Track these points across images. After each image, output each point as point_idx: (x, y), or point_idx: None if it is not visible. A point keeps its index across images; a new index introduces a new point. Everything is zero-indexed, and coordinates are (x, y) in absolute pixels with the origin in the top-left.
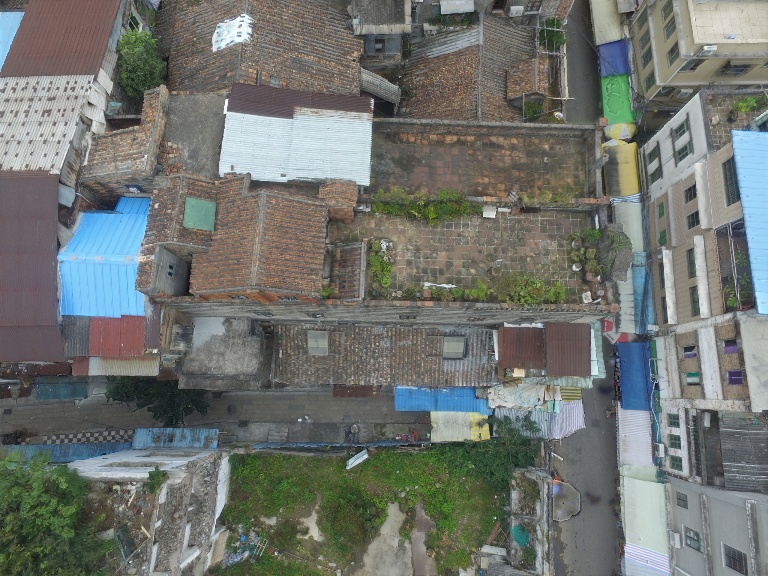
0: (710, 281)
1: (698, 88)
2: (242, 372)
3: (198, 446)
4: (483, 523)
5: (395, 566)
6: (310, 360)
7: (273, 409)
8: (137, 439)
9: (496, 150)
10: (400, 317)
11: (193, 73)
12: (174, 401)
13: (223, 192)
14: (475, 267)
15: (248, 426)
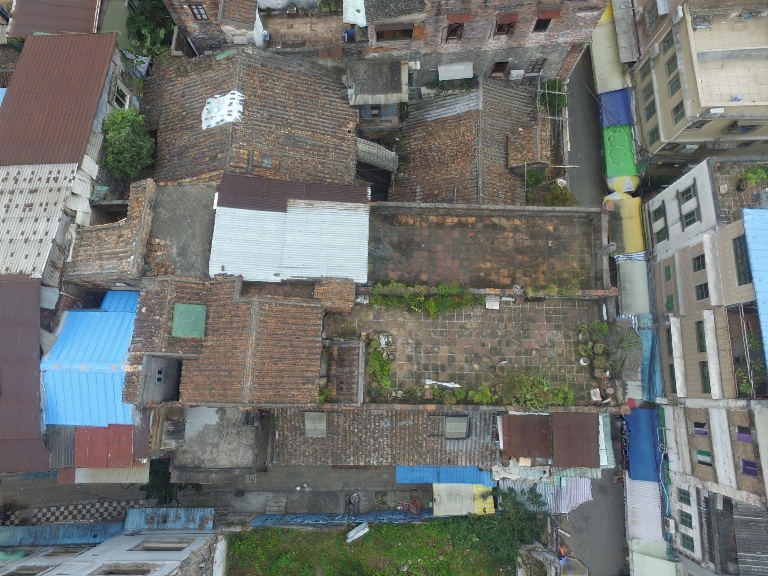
0: (721, 360)
1: (704, 144)
2: (237, 464)
3: (193, 527)
4: None
5: None
6: (308, 441)
7: (270, 477)
8: (129, 520)
9: (498, 232)
10: None
11: (182, 150)
12: (168, 477)
13: (214, 294)
14: (478, 362)
15: (245, 495)
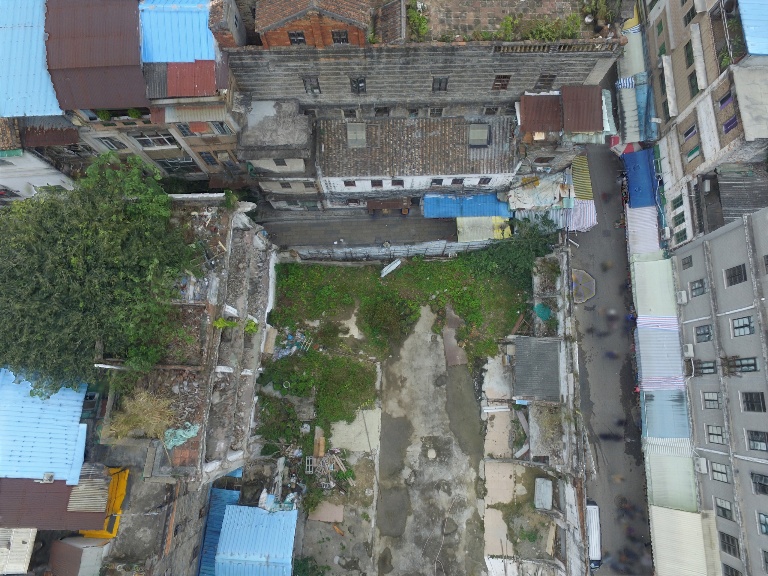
0: (706, 57)
1: None
2: None
3: None
4: (508, 317)
5: (429, 357)
6: (349, 154)
7: (311, 234)
8: None
9: None
10: (433, 85)
11: None
12: None
13: None
14: None
15: (289, 249)
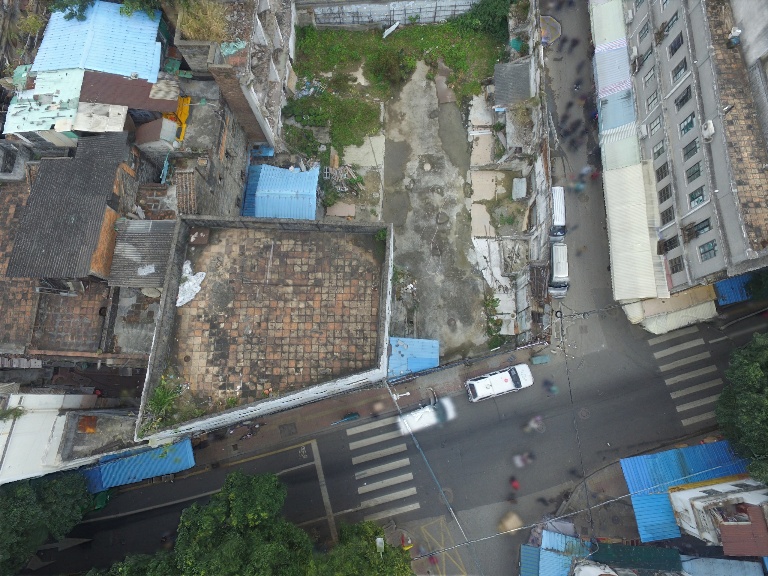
0: None
1: None
2: None
3: None
4: (489, 64)
5: (424, 98)
6: None
7: None
8: None
9: None
10: None
11: None
12: None
13: None
14: None
15: None
